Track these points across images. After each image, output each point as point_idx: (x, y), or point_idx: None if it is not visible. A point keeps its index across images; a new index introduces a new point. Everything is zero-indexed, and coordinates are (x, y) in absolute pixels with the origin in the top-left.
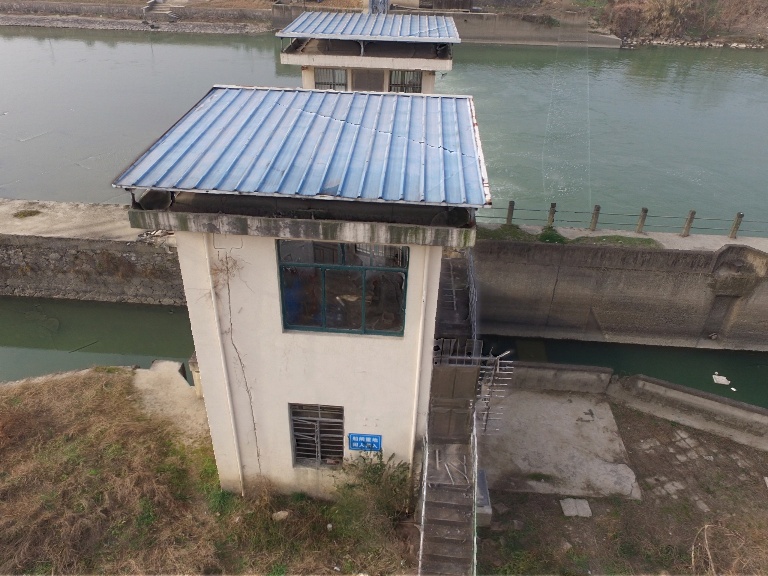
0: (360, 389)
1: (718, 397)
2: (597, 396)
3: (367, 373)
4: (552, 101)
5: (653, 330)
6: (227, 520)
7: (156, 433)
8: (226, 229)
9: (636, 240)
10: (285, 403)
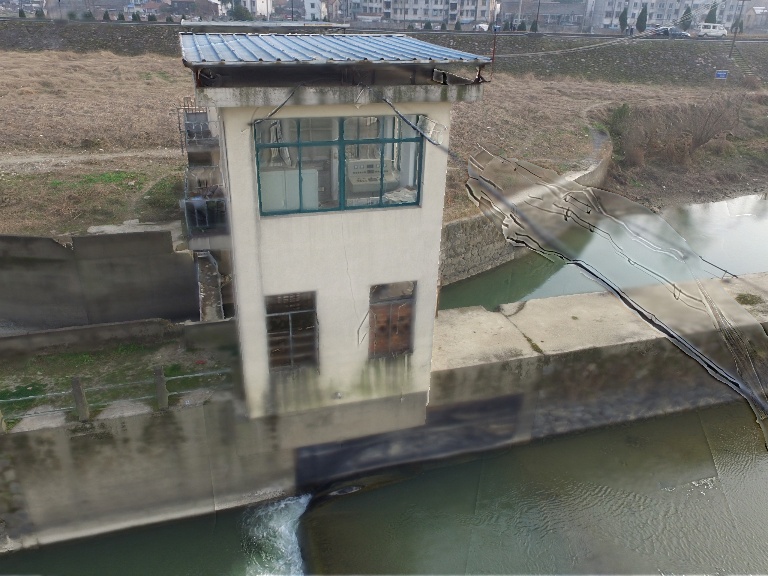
0: None
1: (1, 234)
2: None
3: None
4: None
5: None
6: None
7: None
8: None
9: None
10: None
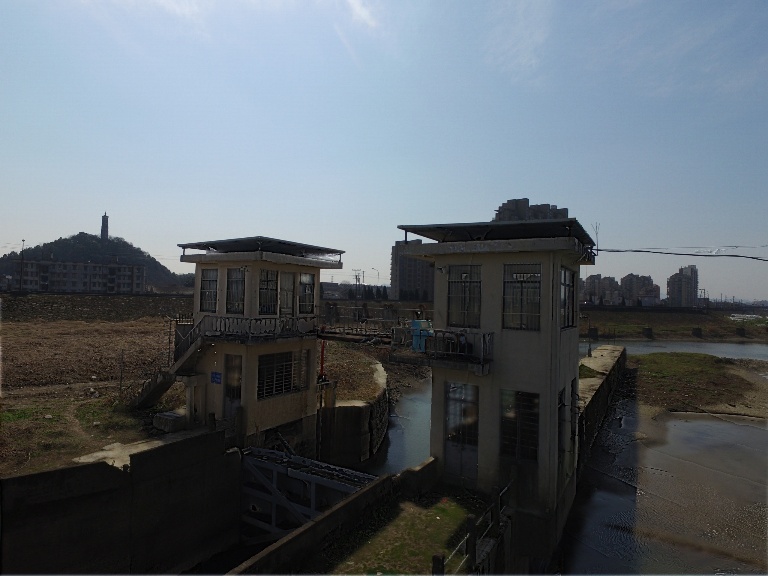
0: None
1: None
2: None
3: None
4: None
5: None
6: None
7: None
8: None
9: None
10: None
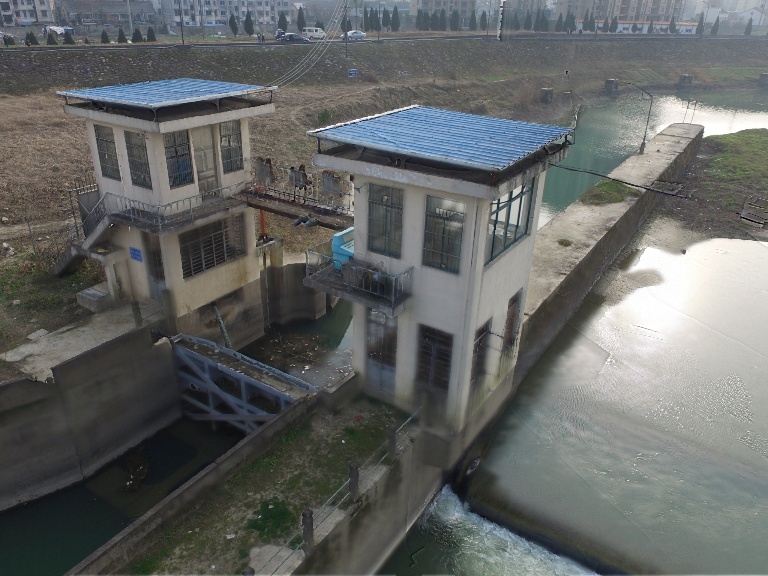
0: None
1: None
2: None
3: None
4: None
5: None
6: None
7: None
8: None
9: None
10: None
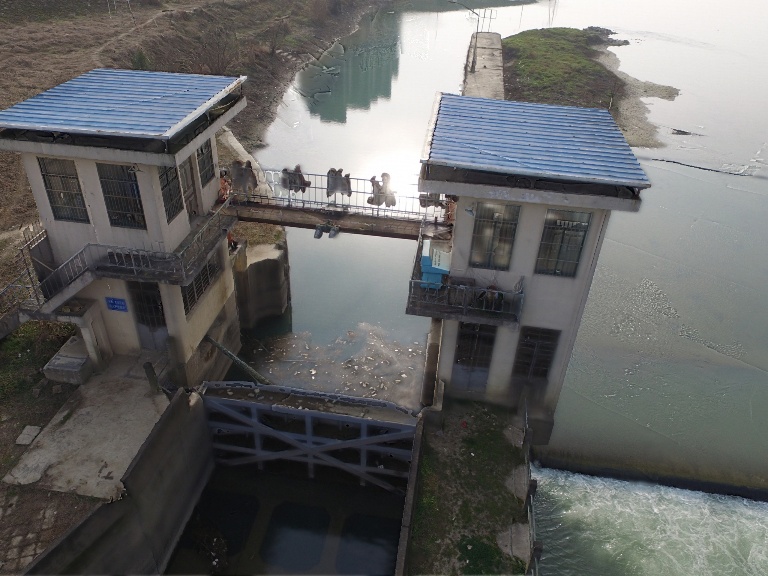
0: None
1: (25, 569)
2: None
3: None
4: None
5: None
6: None
7: None
8: None
9: None
10: None
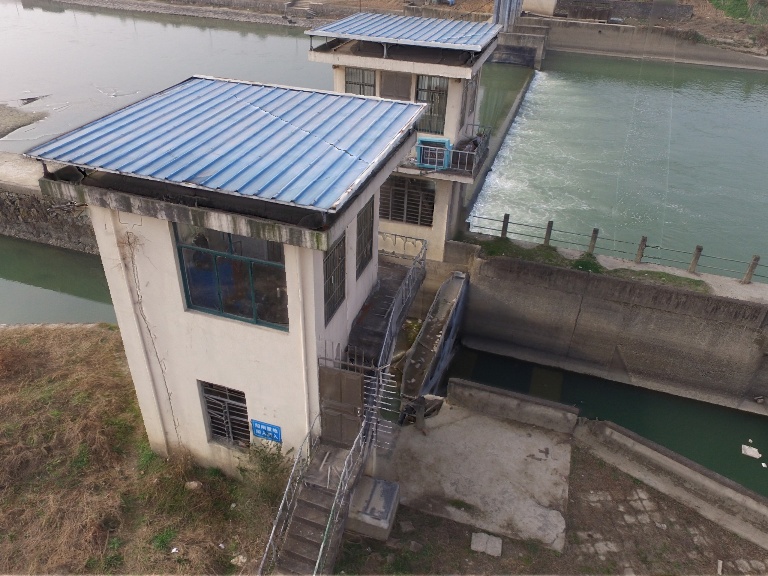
0: (256, 377)
1: (688, 461)
2: (562, 436)
3: (260, 363)
4: (633, 121)
5: (687, 381)
6: (147, 479)
7: (123, 390)
8: (115, 205)
9: (683, 280)
10: (194, 379)
